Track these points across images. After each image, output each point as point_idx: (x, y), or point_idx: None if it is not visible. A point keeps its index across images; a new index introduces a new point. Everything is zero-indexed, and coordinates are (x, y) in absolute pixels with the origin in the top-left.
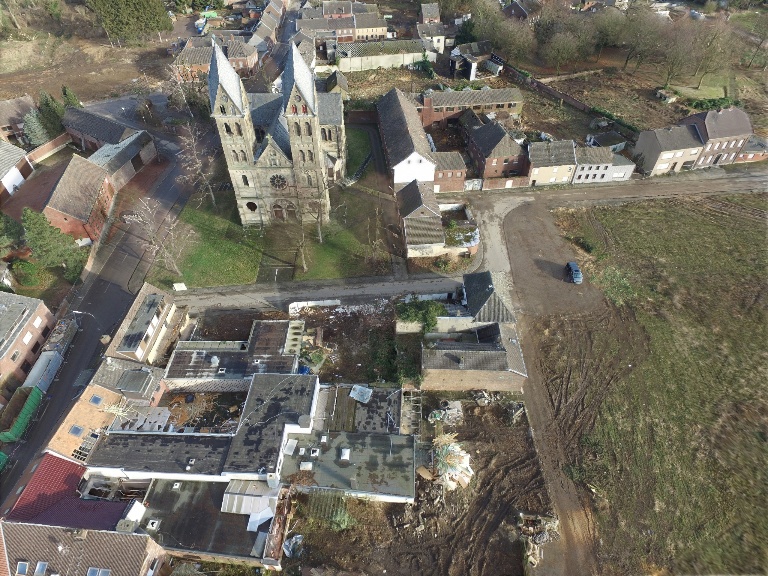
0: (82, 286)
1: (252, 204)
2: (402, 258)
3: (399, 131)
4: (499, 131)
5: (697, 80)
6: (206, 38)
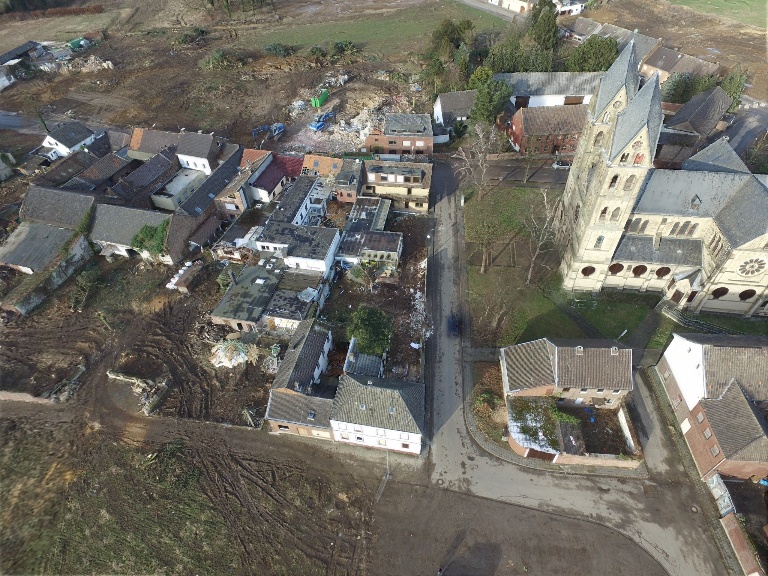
0: None
1: None
2: None
3: None
4: None
5: None
6: None
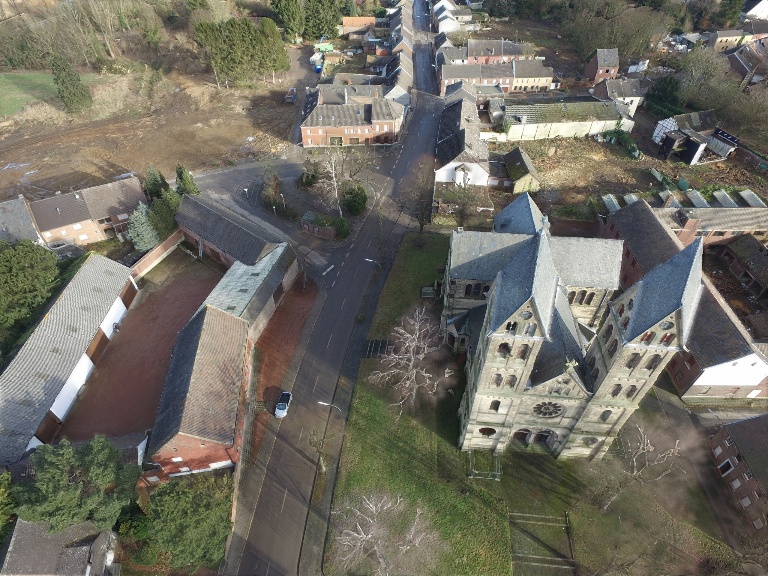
0: (225, 571)
1: (489, 429)
2: (760, 566)
3: None
4: None
5: None
6: (338, 88)
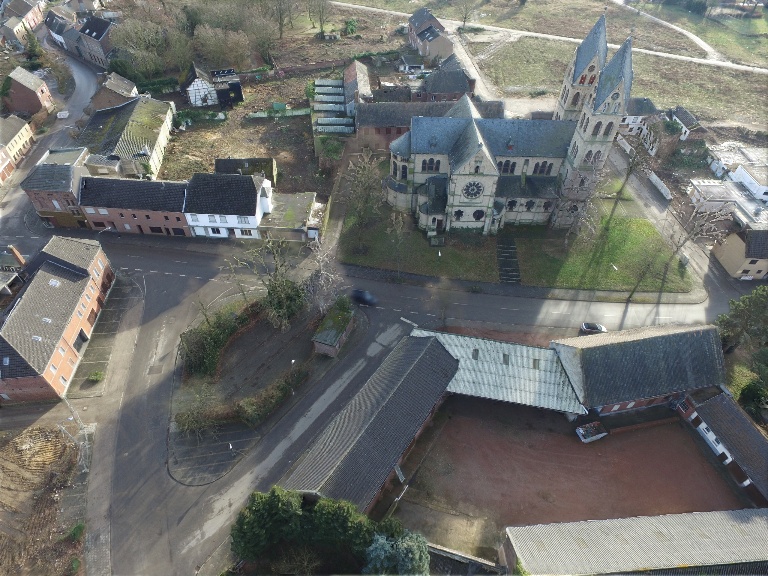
0: None
1: None
2: None
3: None
4: (453, 73)
5: (299, 24)
6: None
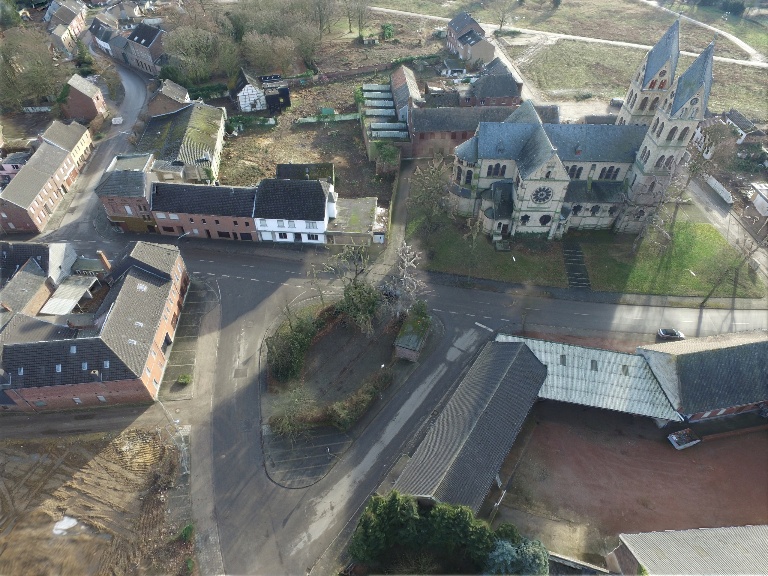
0: None
1: None
2: None
3: (508, 115)
4: (502, 77)
5: (336, 29)
6: (8, 323)
